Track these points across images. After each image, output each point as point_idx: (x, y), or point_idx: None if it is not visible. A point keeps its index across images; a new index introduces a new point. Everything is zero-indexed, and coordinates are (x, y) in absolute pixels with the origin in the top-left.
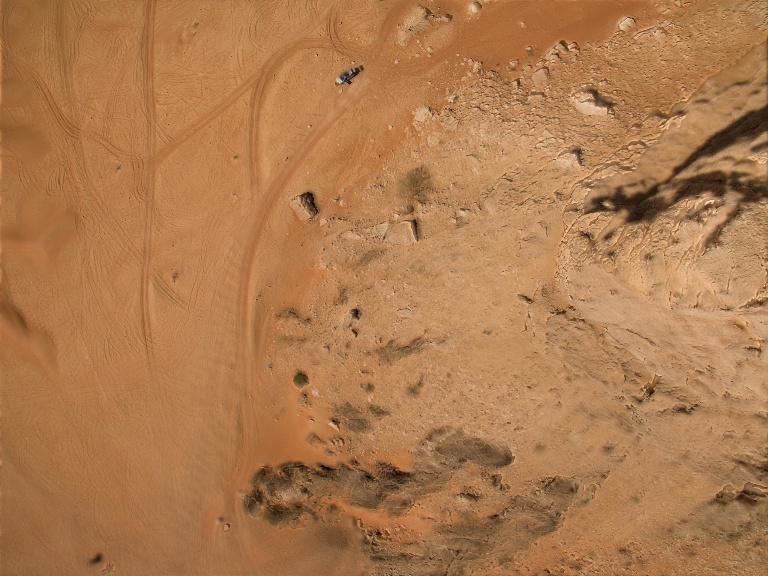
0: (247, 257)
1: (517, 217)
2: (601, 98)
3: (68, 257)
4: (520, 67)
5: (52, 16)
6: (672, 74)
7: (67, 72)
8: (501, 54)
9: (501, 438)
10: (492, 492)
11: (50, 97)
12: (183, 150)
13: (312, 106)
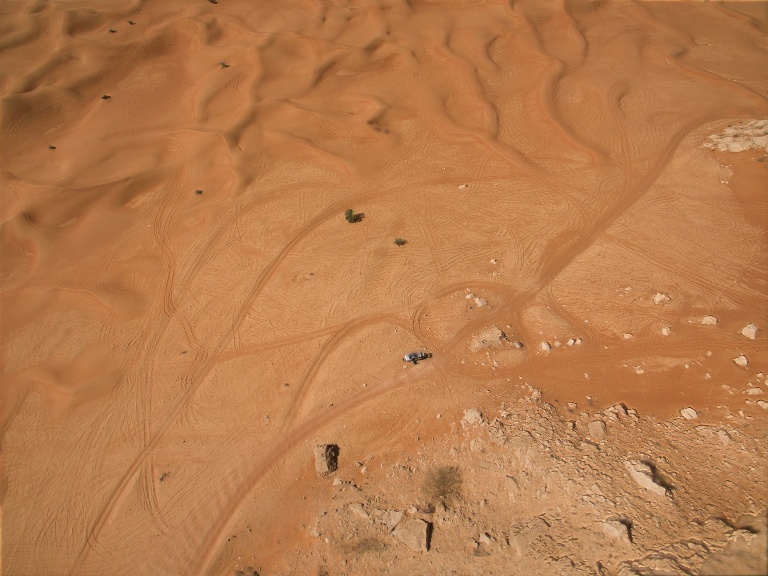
0: (246, 486)
1: (548, 573)
2: (659, 474)
3: (87, 410)
4: (578, 411)
5: (212, 231)
6: (737, 480)
7: (196, 268)
8: (561, 392)
9: None
10: None
11: (171, 280)
12: (246, 360)
13: (375, 369)
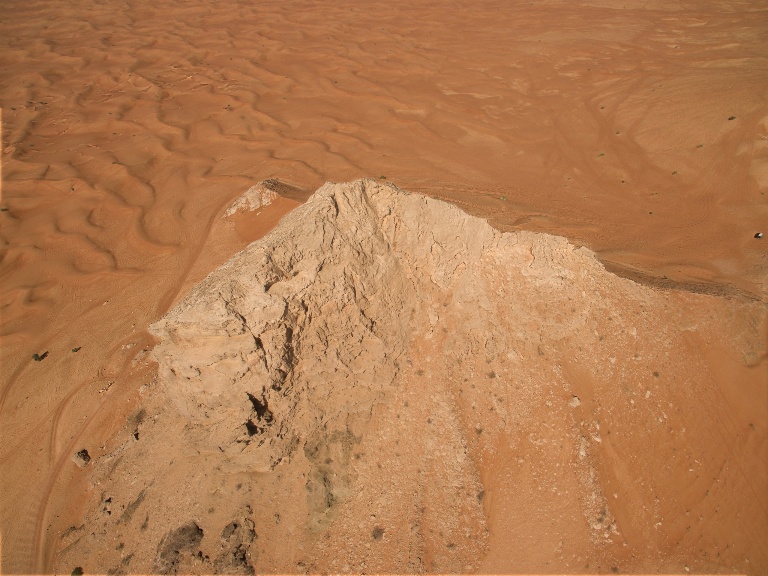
0: (43, 504)
1: None
2: None
3: None
4: None
5: None
6: None
7: None
8: None
9: (189, 519)
10: (201, 570)
11: None
12: (8, 462)
13: (87, 407)
